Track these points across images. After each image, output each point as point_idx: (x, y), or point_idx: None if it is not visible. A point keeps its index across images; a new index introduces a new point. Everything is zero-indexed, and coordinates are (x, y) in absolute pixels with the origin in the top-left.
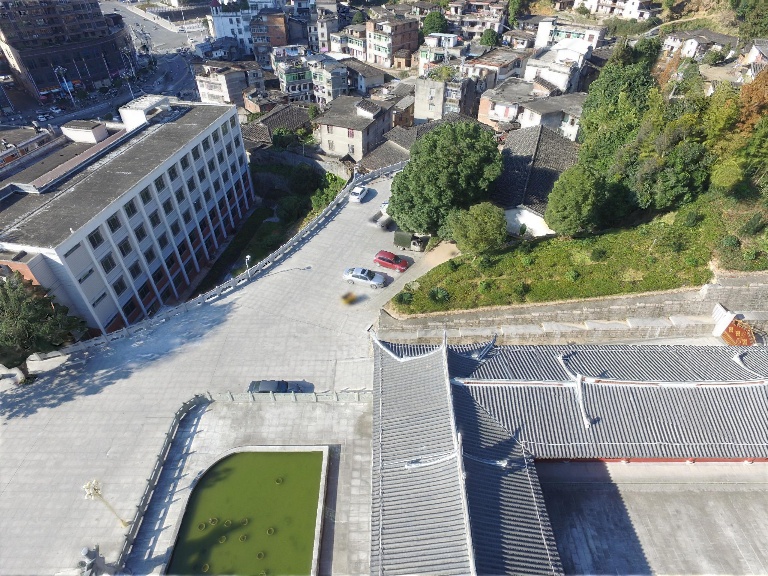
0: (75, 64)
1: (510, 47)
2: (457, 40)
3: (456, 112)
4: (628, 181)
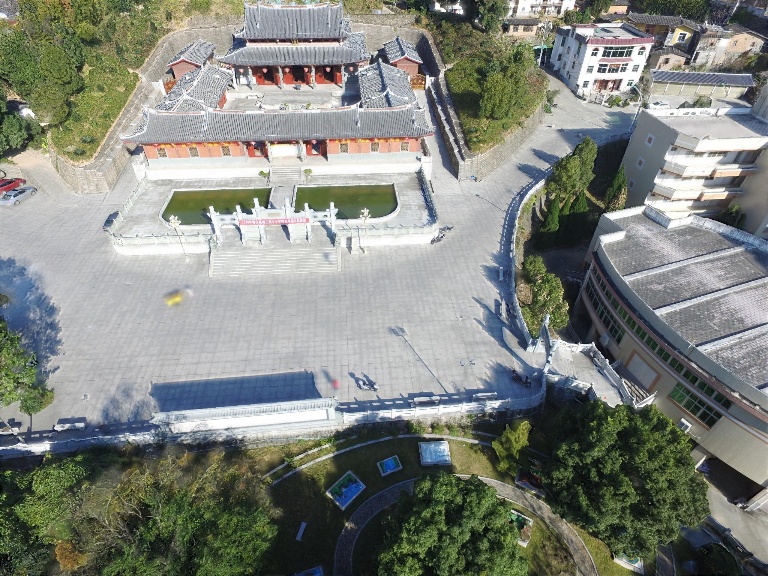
0: None
1: None
2: None
3: None
4: None
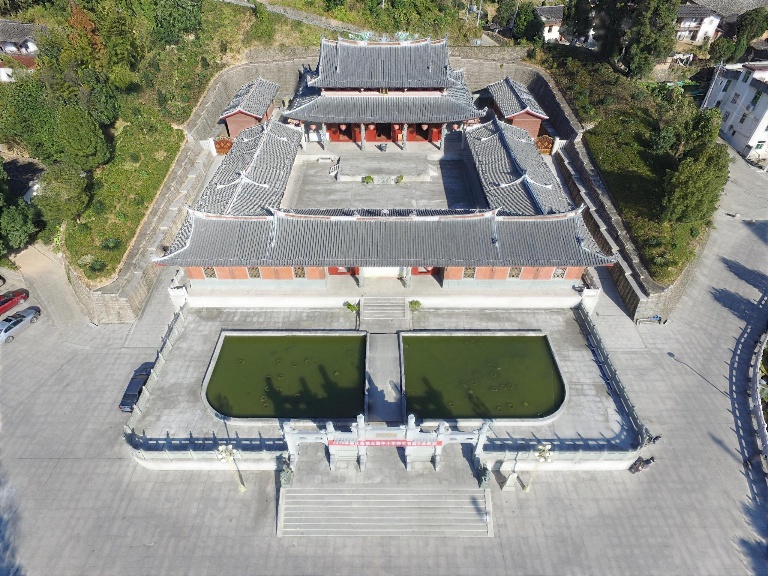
0: None
1: None
2: None
3: None
4: None
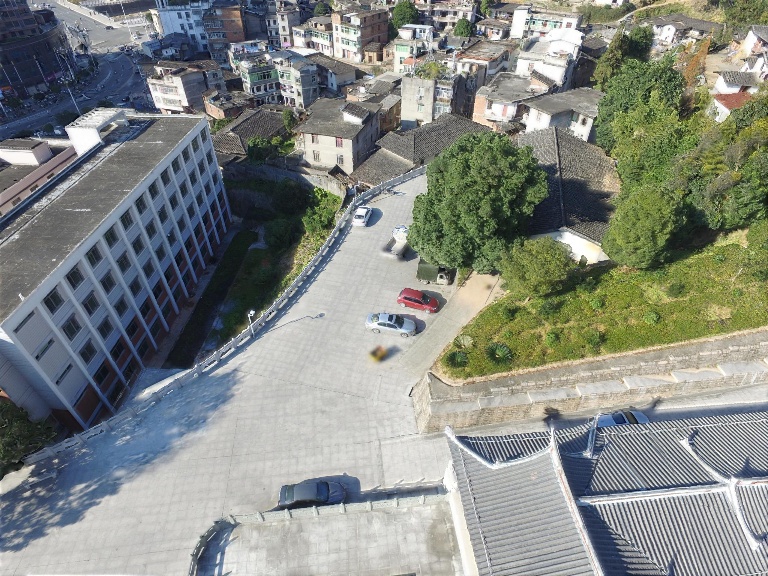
0: (3, 68)
1: (485, 37)
2: None
3: (449, 112)
4: (692, 198)
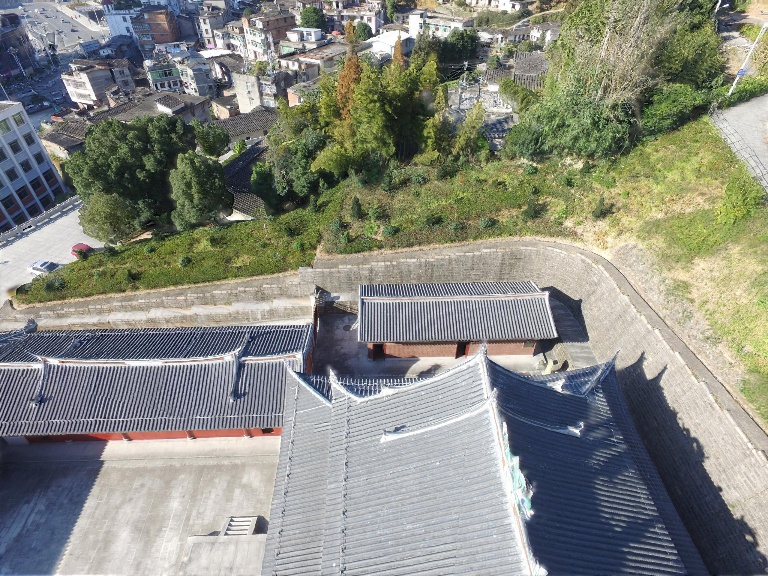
0: None
1: None
2: (321, 34)
3: None
4: (274, 169)
